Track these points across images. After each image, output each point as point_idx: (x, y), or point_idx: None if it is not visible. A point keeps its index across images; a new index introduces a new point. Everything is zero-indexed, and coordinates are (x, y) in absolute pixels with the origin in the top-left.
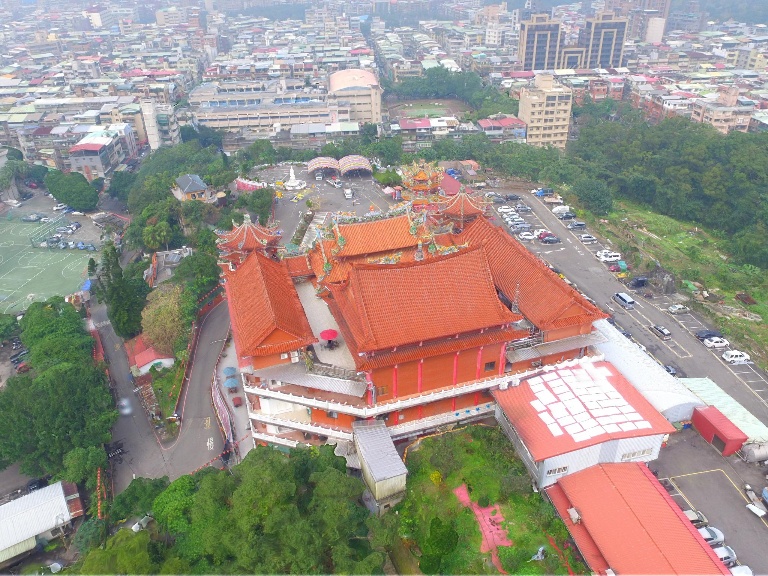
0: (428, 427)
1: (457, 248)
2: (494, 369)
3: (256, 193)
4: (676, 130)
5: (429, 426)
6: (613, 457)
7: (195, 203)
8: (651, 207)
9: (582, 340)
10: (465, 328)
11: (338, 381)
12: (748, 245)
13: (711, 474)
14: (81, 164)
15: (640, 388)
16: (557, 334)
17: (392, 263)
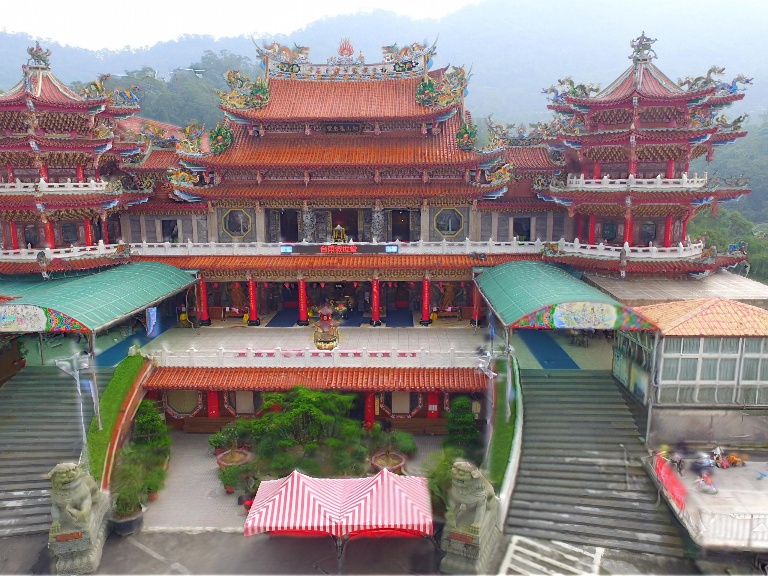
0: None
1: None
2: None
3: None
4: None
5: None
6: None
7: None
8: None
9: None
10: None
11: None
12: None
13: None
14: None
15: None
16: None
17: None
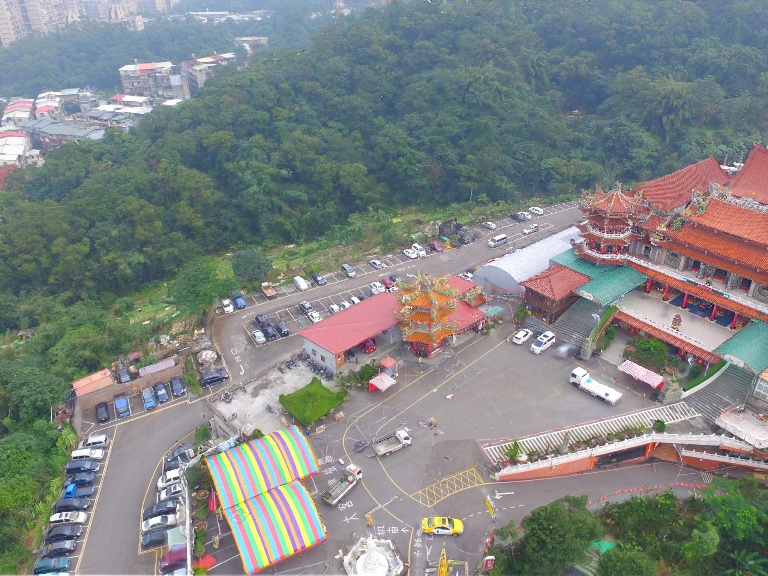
0: None
1: None
2: None
3: (567, 526)
4: (2, 222)
5: None
6: None
7: None
8: (157, 281)
9: None
10: None
11: None
12: (296, 224)
13: None
14: None
15: None
16: None
17: None
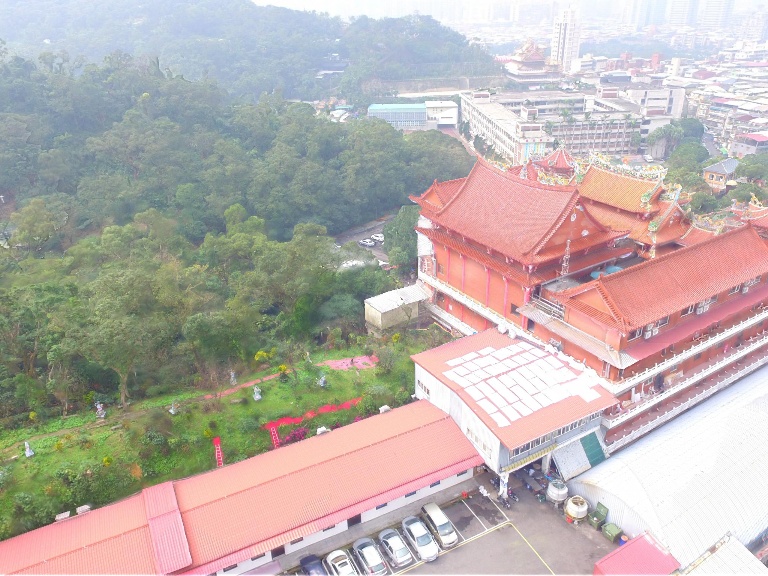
0: (455, 327)
1: (555, 182)
2: (519, 317)
3: (743, 185)
4: None
5: (456, 326)
6: (460, 421)
7: (694, 178)
8: None
9: (599, 348)
10: (490, 243)
11: (429, 244)
12: None
13: (542, 567)
14: (738, 150)
15: (635, 466)
16: (579, 321)
17: (503, 170)
